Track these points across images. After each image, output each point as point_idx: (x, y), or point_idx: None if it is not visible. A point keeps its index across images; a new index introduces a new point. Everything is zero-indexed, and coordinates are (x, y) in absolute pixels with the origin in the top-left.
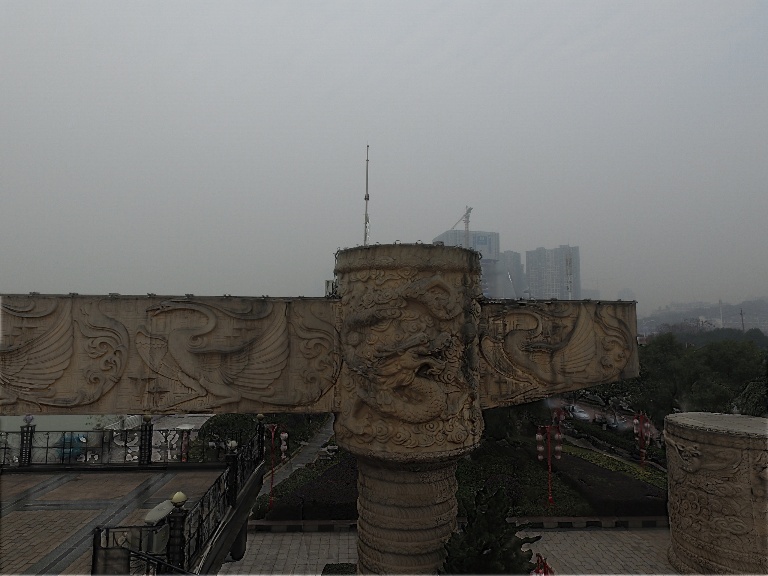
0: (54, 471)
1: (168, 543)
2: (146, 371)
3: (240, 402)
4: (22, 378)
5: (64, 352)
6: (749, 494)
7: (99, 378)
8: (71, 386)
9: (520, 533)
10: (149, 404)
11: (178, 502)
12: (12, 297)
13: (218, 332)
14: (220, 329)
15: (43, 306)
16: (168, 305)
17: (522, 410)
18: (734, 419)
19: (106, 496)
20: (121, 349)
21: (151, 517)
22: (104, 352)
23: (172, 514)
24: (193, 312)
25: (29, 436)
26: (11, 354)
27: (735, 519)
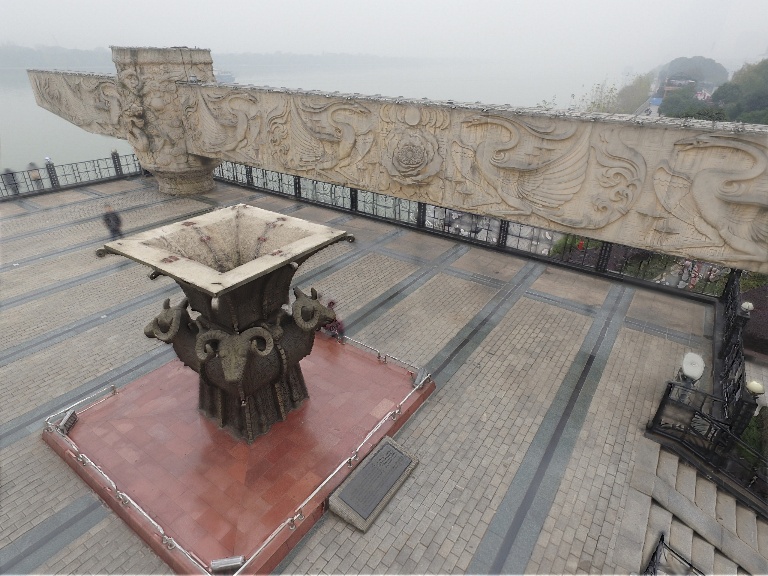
0: (524, 257)
1: (735, 418)
2: (657, 209)
3: (765, 263)
4: (537, 195)
5: (577, 177)
6: None
7: (607, 208)
8: (578, 209)
9: None
10: (653, 241)
11: (757, 393)
12: (535, 117)
13: (763, 179)
14: (767, 176)
15: (563, 128)
16: (706, 141)
17: None
18: None
19: (585, 301)
20: (637, 183)
21: (691, 373)
22: (617, 183)
23: (747, 399)
24: (735, 151)
25: (506, 225)
26: (530, 172)
27: None
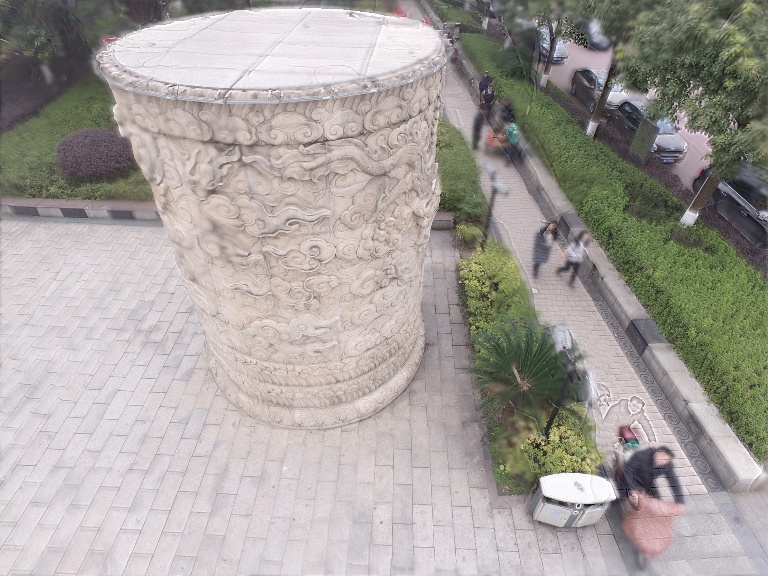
0: None
1: None
2: None
3: None
4: None
5: None
6: (197, 247)
7: None
8: None
9: (73, 227)
10: None
11: None
12: None
13: None
14: None
15: None
16: None
17: (201, 4)
18: (338, 30)
19: None
20: None
21: None
22: None
23: None
24: None
25: None
26: None
27: (194, 287)
